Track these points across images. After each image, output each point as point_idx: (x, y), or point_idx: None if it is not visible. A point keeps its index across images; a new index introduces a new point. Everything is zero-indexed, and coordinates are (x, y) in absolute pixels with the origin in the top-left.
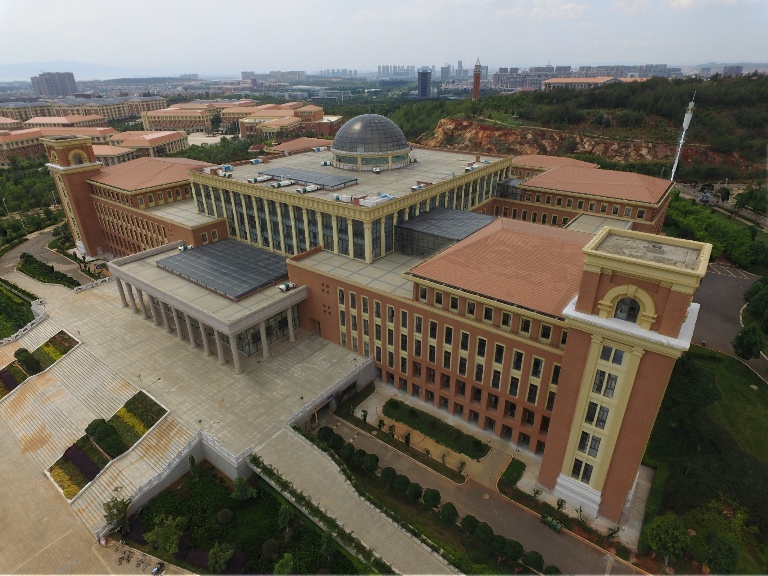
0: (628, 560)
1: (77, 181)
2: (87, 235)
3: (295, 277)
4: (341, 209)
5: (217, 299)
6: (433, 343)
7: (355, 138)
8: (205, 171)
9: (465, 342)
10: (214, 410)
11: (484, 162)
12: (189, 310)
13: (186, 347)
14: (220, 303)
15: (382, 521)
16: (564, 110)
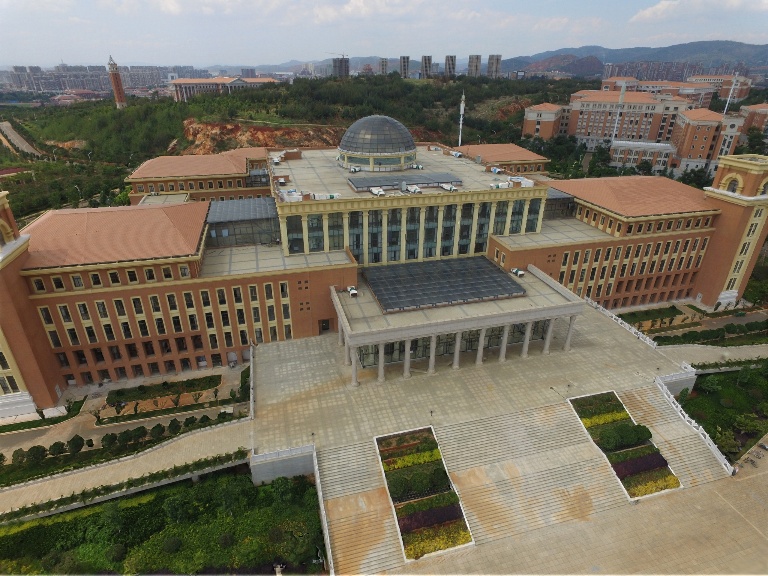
0: (763, 309)
1: (12, 278)
2: (41, 371)
3: (518, 262)
4: (521, 193)
5: (512, 302)
6: (636, 261)
7: (395, 138)
8: (291, 200)
9: (657, 250)
10: (620, 371)
11: (435, 150)
12: (526, 316)
13: (500, 364)
14: (522, 302)
15: (743, 349)
16: (321, 107)
